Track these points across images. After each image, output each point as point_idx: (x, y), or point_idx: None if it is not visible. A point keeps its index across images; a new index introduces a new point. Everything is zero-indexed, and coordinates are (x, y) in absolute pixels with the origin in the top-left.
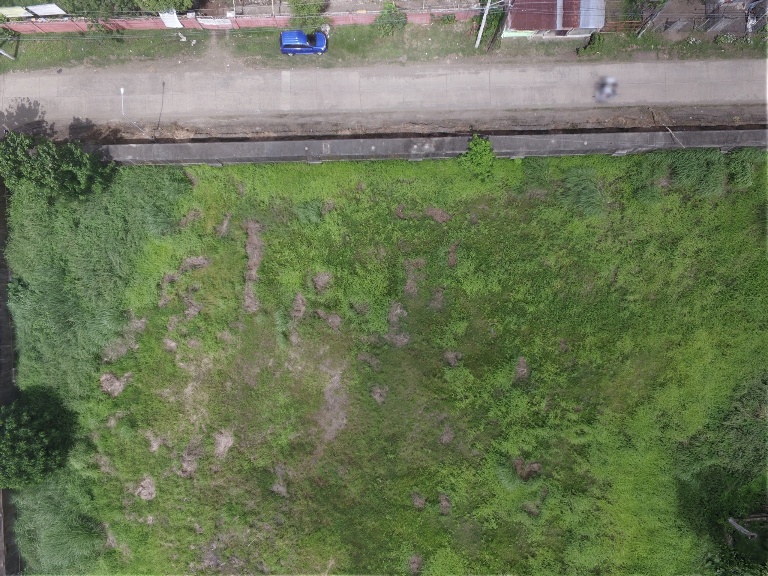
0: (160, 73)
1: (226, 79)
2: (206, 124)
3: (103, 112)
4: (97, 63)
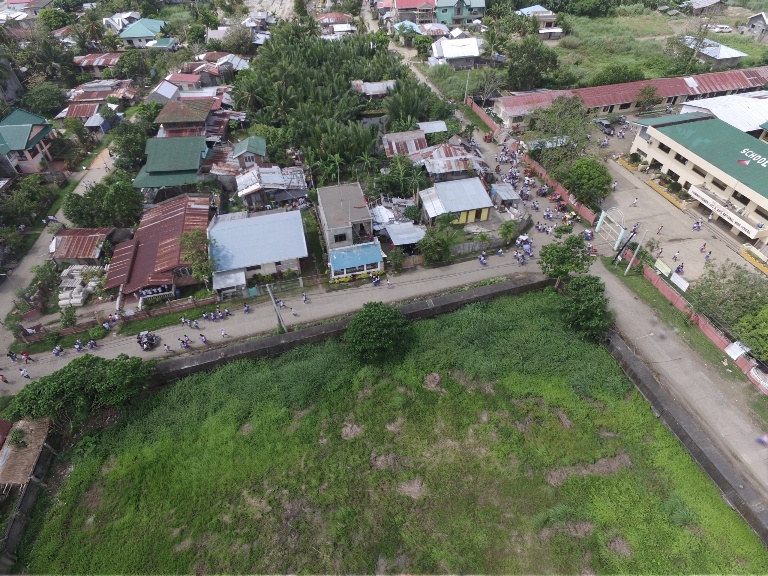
0: (685, 354)
1: (724, 402)
2: (676, 396)
3: (627, 327)
4: (659, 315)
